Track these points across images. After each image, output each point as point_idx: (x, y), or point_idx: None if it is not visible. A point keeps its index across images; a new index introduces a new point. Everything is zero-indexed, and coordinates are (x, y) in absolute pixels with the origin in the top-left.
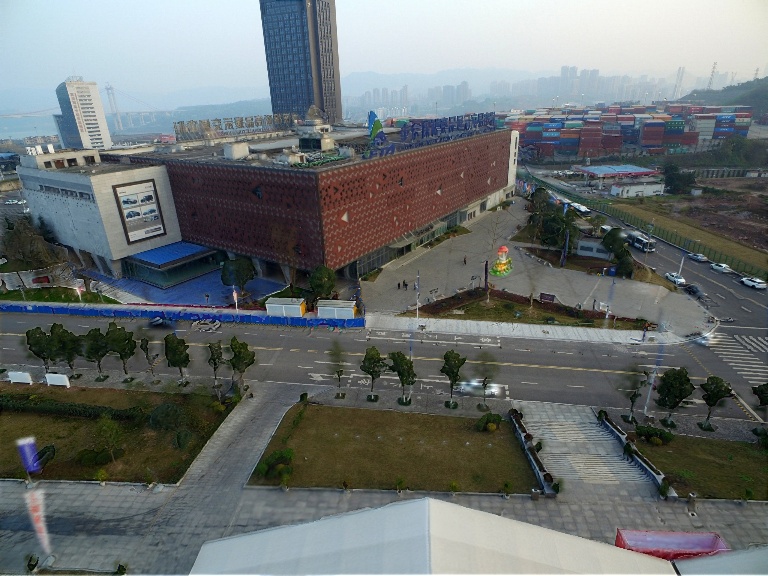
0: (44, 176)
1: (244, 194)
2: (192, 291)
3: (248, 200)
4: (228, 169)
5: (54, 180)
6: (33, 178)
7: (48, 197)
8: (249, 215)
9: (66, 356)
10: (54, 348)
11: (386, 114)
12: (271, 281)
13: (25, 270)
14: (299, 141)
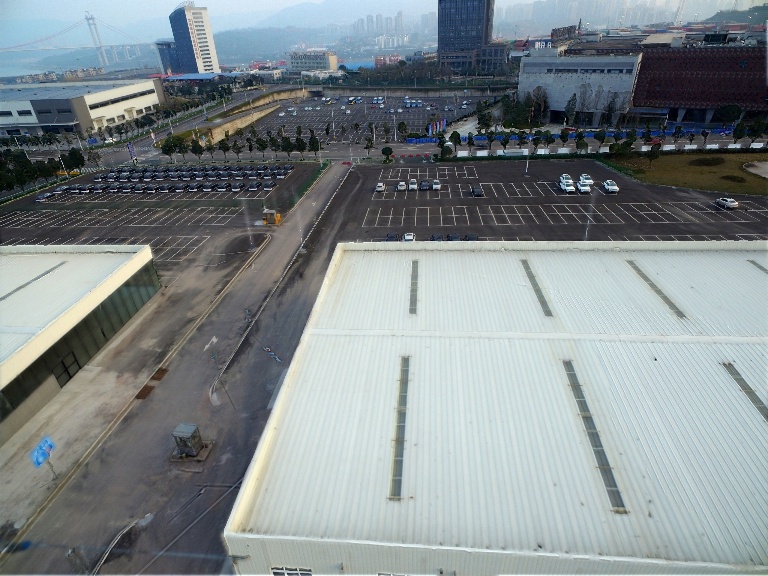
0: (566, 61)
1: (727, 66)
2: (685, 129)
3: (730, 69)
4: (719, 50)
5: (581, 63)
6: (544, 64)
7: (560, 76)
8: (725, 80)
9: (759, 135)
10: (764, 128)
11: (526, 33)
12: (721, 124)
13: (535, 128)
14: (706, 36)
